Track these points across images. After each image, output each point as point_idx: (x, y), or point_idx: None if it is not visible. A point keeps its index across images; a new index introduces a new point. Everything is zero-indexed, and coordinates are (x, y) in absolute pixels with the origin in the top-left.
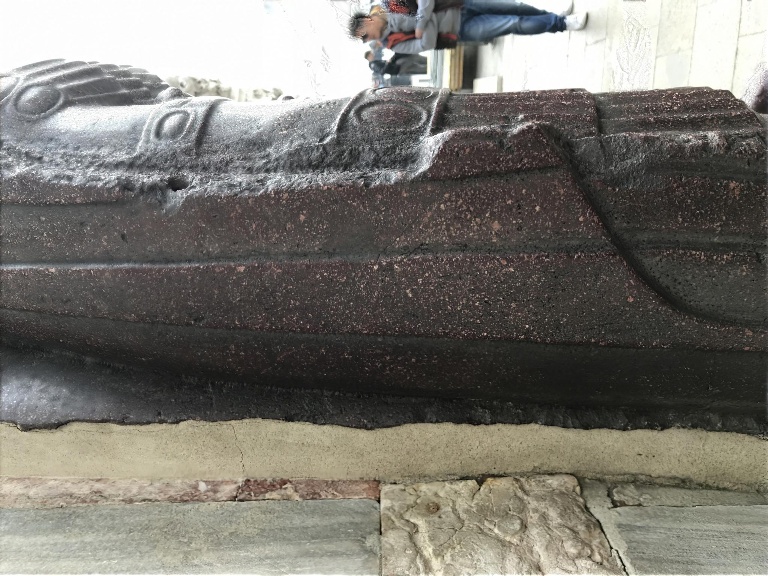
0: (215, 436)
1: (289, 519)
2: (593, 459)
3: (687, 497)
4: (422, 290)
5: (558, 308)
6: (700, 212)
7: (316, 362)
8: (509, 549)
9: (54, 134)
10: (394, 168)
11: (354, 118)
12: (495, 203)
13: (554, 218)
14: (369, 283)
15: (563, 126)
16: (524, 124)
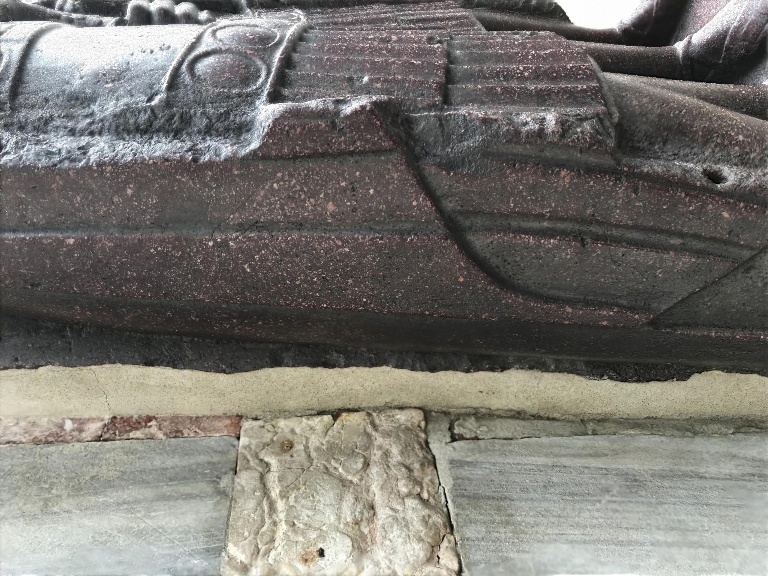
0: (76, 379)
1: (150, 460)
2: (439, 396)
3: (519, 428)
4: (260, 266)
5: (393, 285)
6: (531, 198)
7: (164, 322)
8: (348, 489)
9: None
10: (227, 137)
11: (186, 73)
12: (329, 184)
13: (388, 201)
14: (205, 258)
15: (408, 93)
16: (360, 100)
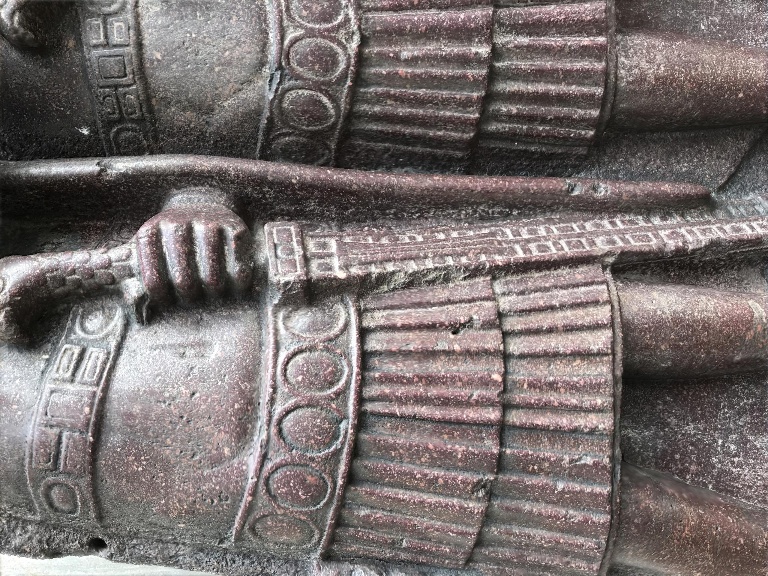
0: None
1: None
2: None
3: None
4: None
5: None
6: None
7: None
8: None
9: None
10: (288, 562)
11: (249, 535)
12: None
13: None
14: None
15: None
16: None
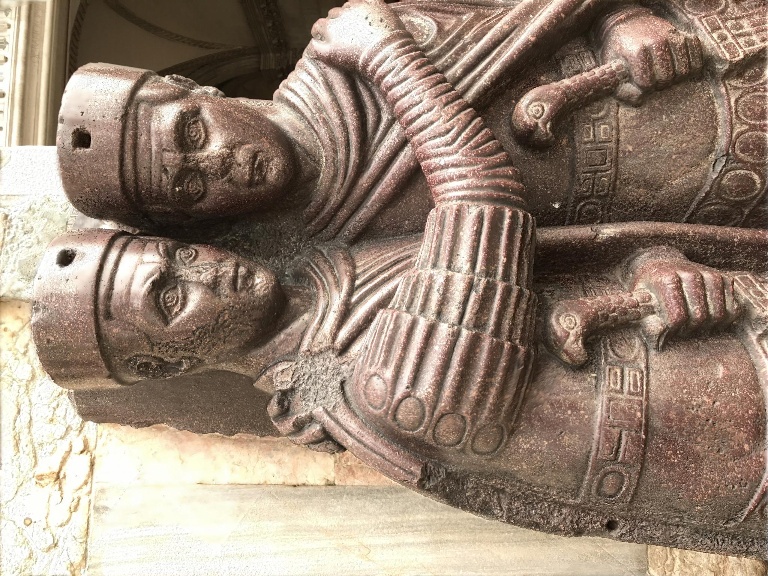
0: None
1: None
2: None
3: None
4: None
5: None
6: None
7: None
8: None
9: (509, 471)
10: None
11: (758, 515)
12: None
13: None
14: None
15: None
16: None
